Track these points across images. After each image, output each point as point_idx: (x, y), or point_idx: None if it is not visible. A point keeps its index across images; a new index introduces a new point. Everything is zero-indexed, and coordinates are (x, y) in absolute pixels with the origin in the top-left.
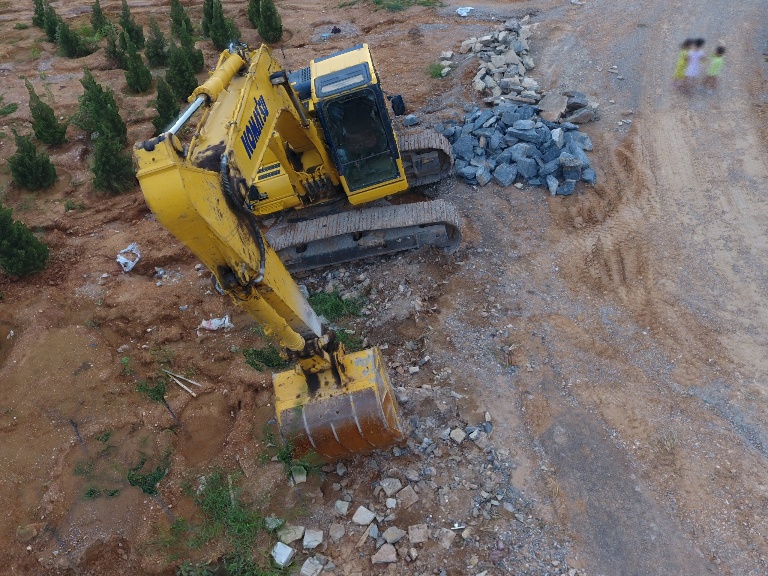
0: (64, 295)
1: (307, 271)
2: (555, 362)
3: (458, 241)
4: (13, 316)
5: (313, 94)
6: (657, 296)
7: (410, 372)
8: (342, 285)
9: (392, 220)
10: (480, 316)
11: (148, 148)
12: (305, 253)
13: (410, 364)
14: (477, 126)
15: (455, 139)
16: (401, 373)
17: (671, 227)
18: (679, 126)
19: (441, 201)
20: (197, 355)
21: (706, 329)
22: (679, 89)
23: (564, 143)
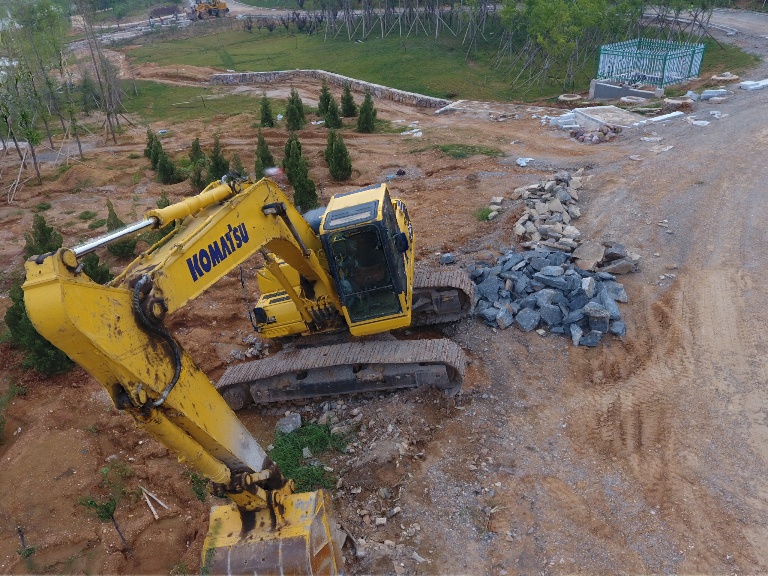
0: (79, 398)
1: (305, 399)
2: (540, 534)
3: (460, 384)
4: (26, 413)
5: (321, 226)
6: (674, 470)
7: (376, 523)
8: (336, 418)
9: (391, 355)
10: (467, 469)
11: (40, 261)
12: (304, 380)
13: (379, 514)
14: (506, 269)
15: (482, 280)
16: (367, 523)
17: (703, 392)
18: (728, 285)
19: (445, 340)
20: (176, 474)
21: (728, 517)
22: (733, 247)
23: (596, 292)
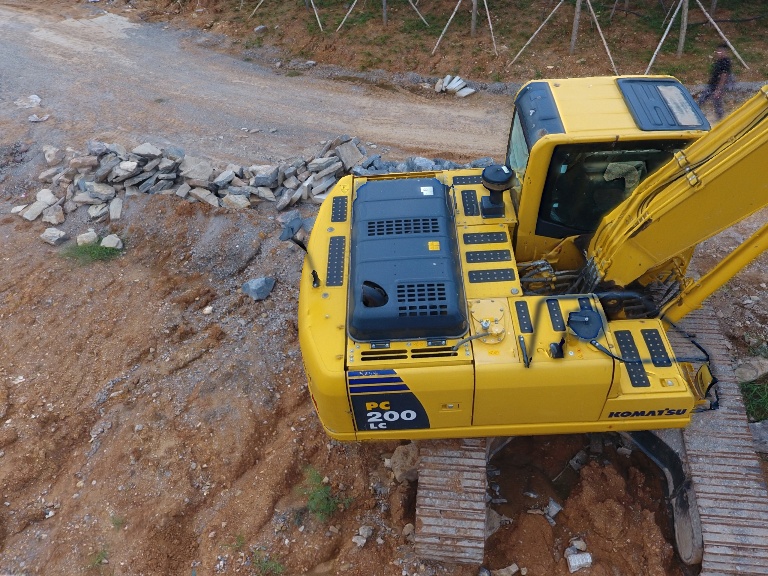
0: None
1: None
2: None
3: None
4: None
5: None
6: None
7: None
8: None
9: None
10: (766, 255)
11: None
12: None
13: None
14: None
15: None
16: None
17: None
18: (387, 127)
19: None
20: None
21: None
22: (316, 114)
23: None
